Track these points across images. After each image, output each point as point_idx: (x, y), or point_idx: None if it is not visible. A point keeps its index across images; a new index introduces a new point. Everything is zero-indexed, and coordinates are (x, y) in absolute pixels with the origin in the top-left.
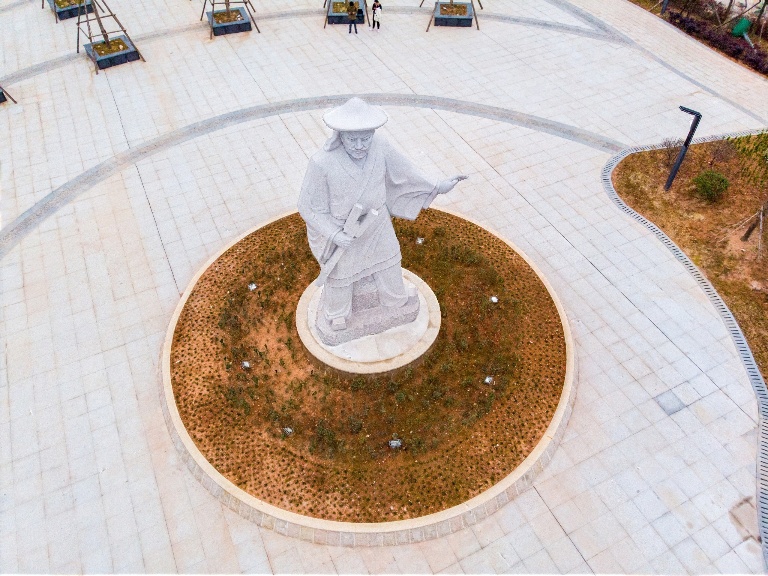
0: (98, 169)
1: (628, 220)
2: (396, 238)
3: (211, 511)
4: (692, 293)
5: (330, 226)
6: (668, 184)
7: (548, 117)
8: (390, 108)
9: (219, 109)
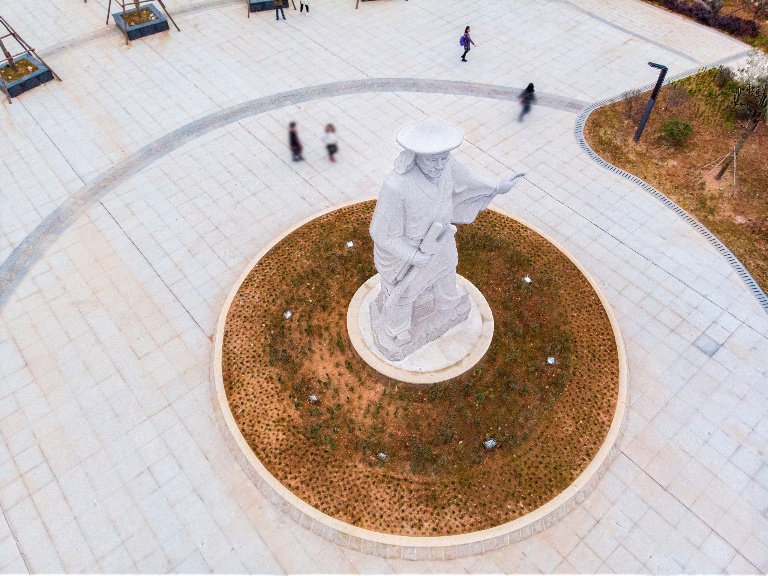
0: (58, 214)
1: (613, 177)
2: None
3: (332, 556)
4: (691, 238)
5: (407, 248)
6: (637, 136)
7: (506, 84)
8: (351, 97)
9: (169, 124)
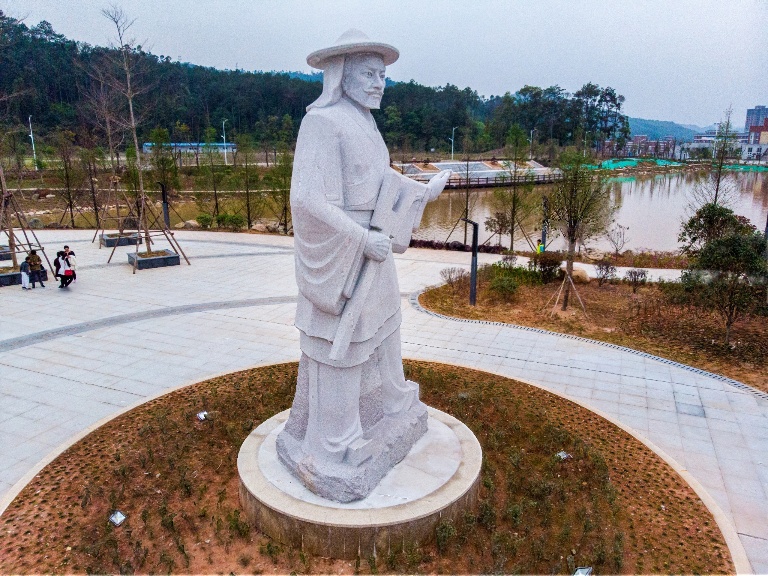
0: None
1: (476, 325)
2: None
3: None
4: (584, 346)
5: (355, 223)
6: (473, 299)
7: None
8: (149, 321)
9: None
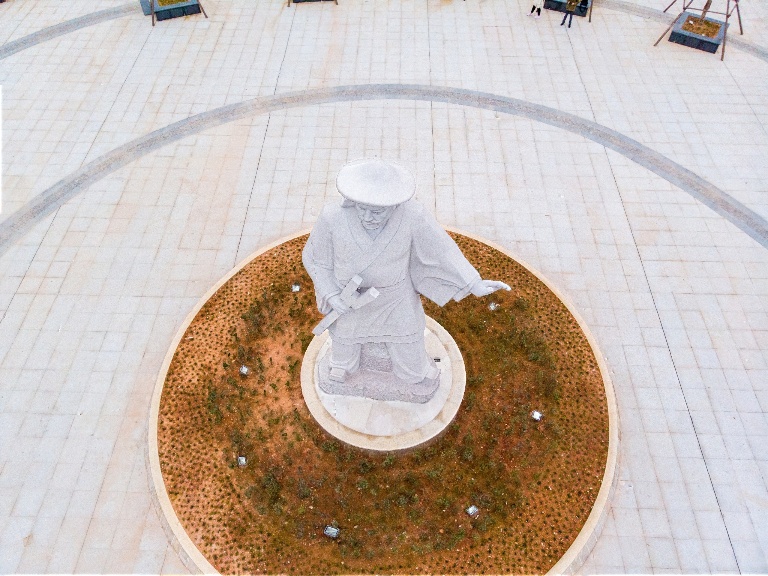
0: (236, 107)
1: None
2: (415, 318)
3: (140, 503)
4: None
5: (328, 285)
6: None
7: (747, 203)
8: (556, 130)
9: (377, 77)
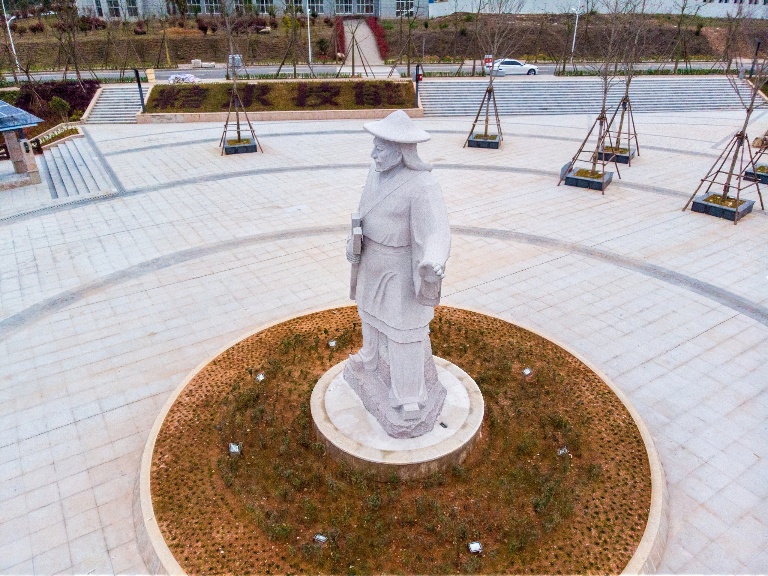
0: (550, 240)
1: None
2: (402, 308)
3: (202, 360)
4: None
5: None
6: None
7: None
8: None
9: (704, 275)
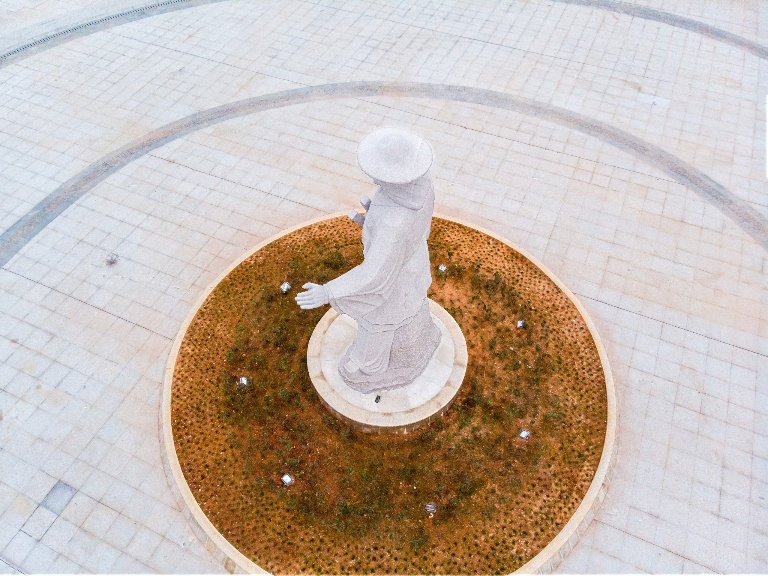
0: None
1: None
2: None
3: None
4: None
5: None
6: None
7: None
8: None
9: None
